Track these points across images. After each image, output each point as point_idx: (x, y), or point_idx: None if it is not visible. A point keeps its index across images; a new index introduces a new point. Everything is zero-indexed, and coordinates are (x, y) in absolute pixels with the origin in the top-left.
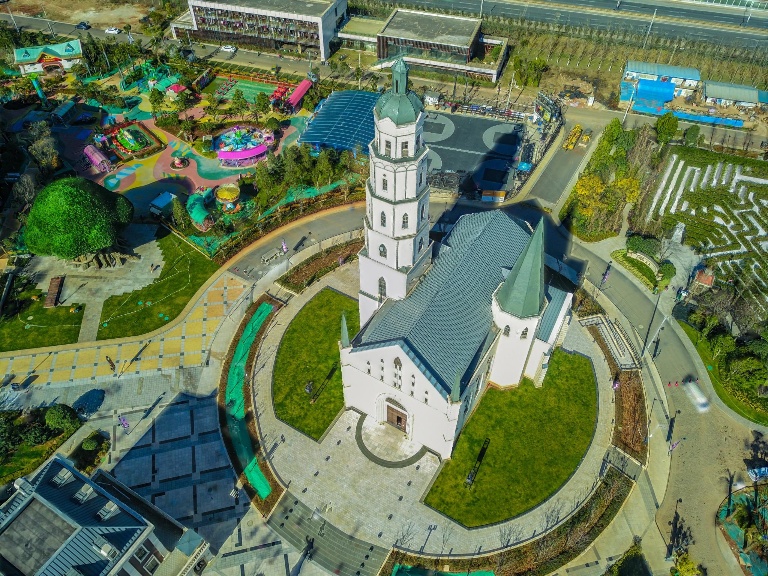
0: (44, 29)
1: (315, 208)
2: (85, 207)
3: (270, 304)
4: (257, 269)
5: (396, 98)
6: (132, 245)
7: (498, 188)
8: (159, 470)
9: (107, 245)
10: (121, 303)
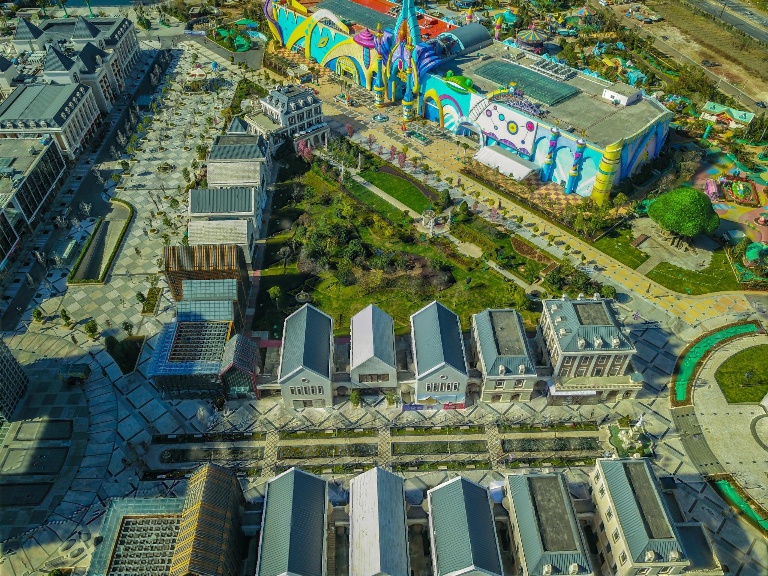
0: (733, 95)
1: None
2: (697, 209)
3: (757, 328)
4: (764, 307)
5: None
6: (697, 246)
7: None
8: None
9: (690, 235)
10: (670, 268)
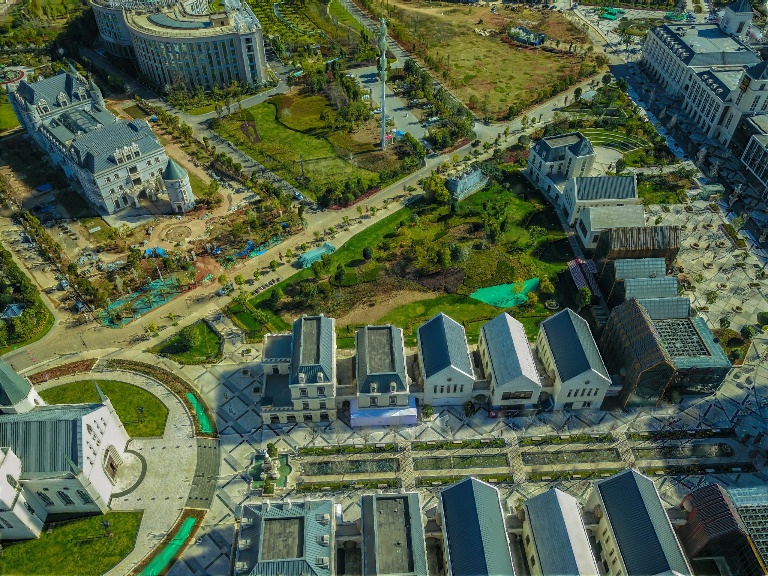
0: None
1: None
2: None
3: None
4: None
5: None
6: None
7: None
8: None
9: None
10: None
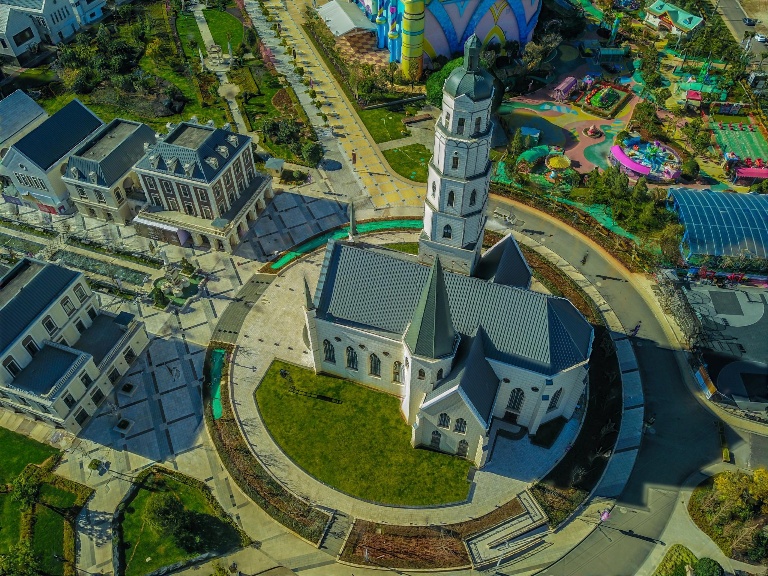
0: (723, 7)
1: (587, 231)
2: None
3: None
4: (487, 212)
5: (460, 69)
6: None
7: (734, 392)
8: (287, 212)
9: None
10: (418, 151)
